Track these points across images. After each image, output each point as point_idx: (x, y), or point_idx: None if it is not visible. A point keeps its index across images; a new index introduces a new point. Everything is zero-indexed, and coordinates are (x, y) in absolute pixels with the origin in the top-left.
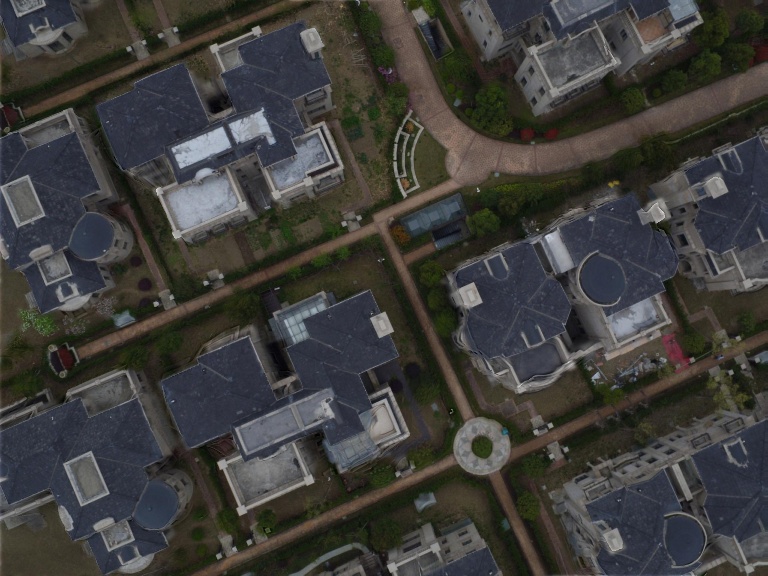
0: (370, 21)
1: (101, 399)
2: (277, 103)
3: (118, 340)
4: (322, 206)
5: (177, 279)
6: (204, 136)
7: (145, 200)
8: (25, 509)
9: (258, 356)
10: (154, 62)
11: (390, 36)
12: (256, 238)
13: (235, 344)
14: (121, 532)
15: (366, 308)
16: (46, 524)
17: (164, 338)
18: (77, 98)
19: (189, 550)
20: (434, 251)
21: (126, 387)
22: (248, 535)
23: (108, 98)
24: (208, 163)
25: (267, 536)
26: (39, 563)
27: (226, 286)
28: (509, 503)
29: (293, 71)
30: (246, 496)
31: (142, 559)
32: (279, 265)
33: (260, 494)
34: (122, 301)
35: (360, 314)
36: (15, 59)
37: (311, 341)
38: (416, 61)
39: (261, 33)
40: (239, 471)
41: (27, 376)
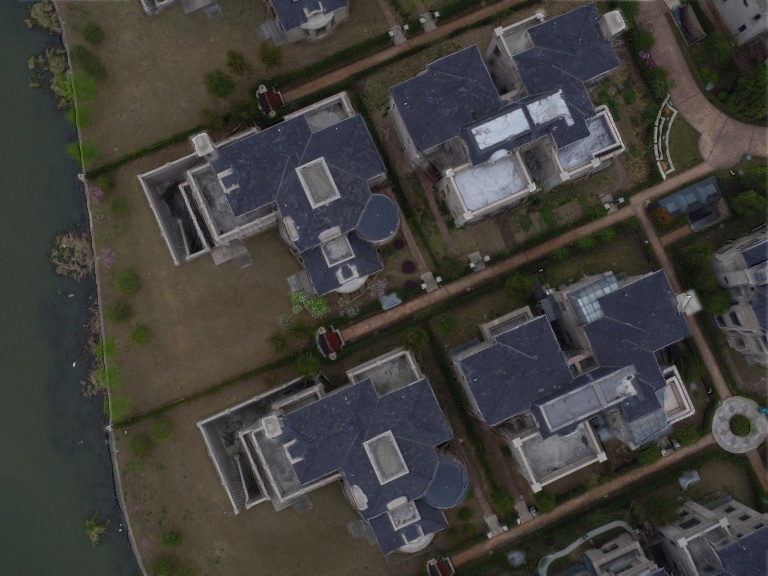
0: (622, 6)
1: (381, 380)
2: (572, 85)
3: (381, 322)
4: (584, 189)
5: (440, 262)
6: (503, 117)
7: (406, 183)
8: (309, 490)
9: (555, 335)
10: (411, 47)
11: (642, 21)
12: (517, 221)
13: (532, 323)
14: (406, 511)
15: (664, 287)
16: (312, 506)
17: (430, 320)
18: (336, 83)
19: (458, 530)
20: (691, 233)
21: (403, 368)
22: (515, 514)
23: (367, 83)
24: (506, 144)
25: (531, 515)
26: (305, 545)
27: (487, 268)
28: (767, 481)
29: (588, 53)
30: (537, 474)
31: (423, 538)
32: (538, 247)
33: (550, 472)
34: (389, 283)
35: (659, 292)
36: (274, 44)
37: (607, 320)
38: (668, 46)
39: (545, 16)
40: (529, 449)
41: (296, 358)
